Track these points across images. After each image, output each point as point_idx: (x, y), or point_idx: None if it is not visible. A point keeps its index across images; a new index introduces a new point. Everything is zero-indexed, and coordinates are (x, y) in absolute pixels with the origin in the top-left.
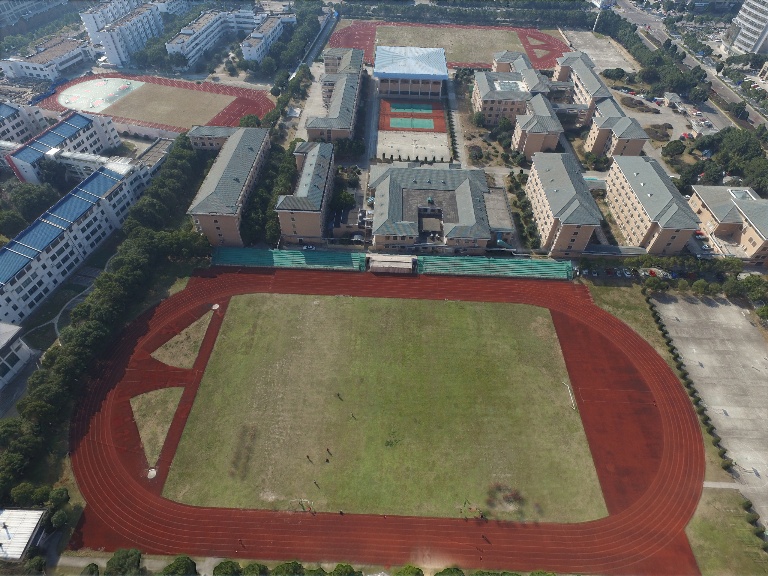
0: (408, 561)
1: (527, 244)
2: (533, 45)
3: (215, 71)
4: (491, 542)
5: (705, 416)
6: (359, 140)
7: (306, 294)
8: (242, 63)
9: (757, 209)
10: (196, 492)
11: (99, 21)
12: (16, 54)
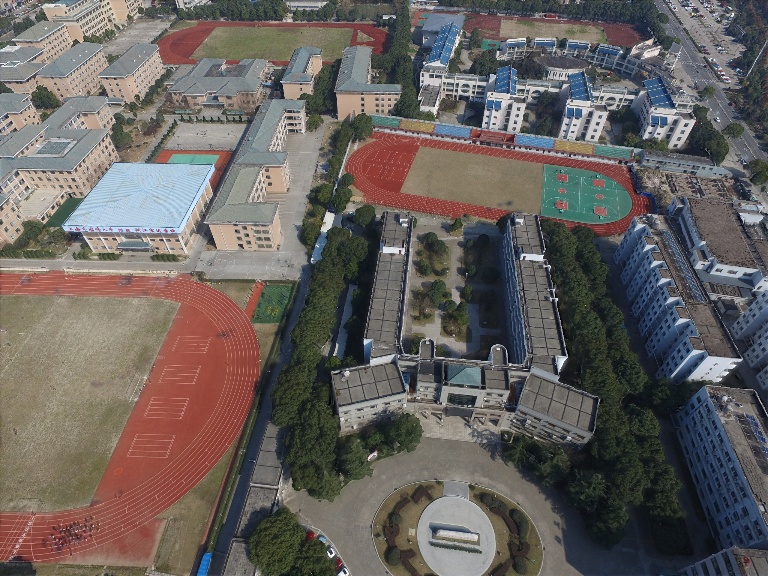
0: None
1: None
2: None
3: None
4: None
5: None
6: (259, 106)
7: None
8: None
9: (24, 54)
10: None
11: None
12: None
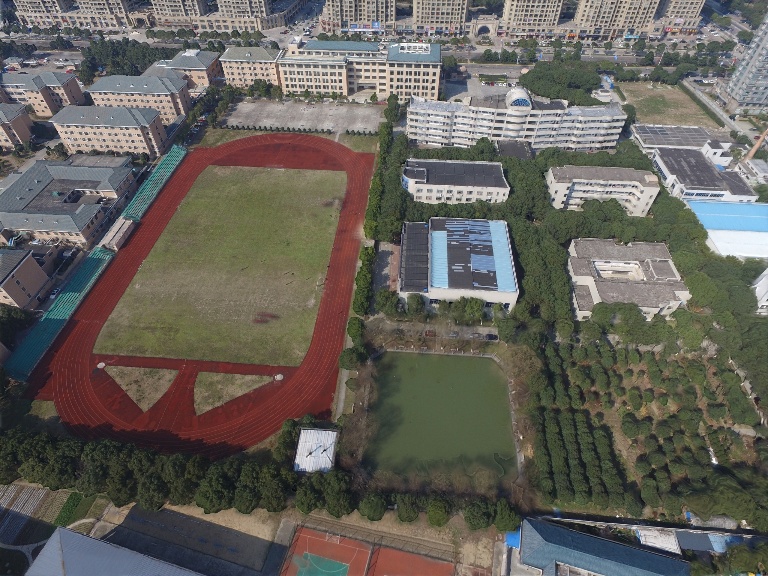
0: (358, 240)
1: (140, 164)
2: None
3: None
4: (353, 210)
5: (304, 129)
6: None
7: (123, 294)
8: None
9: (181, 61)
10: (300, 344)
11: None
12: None
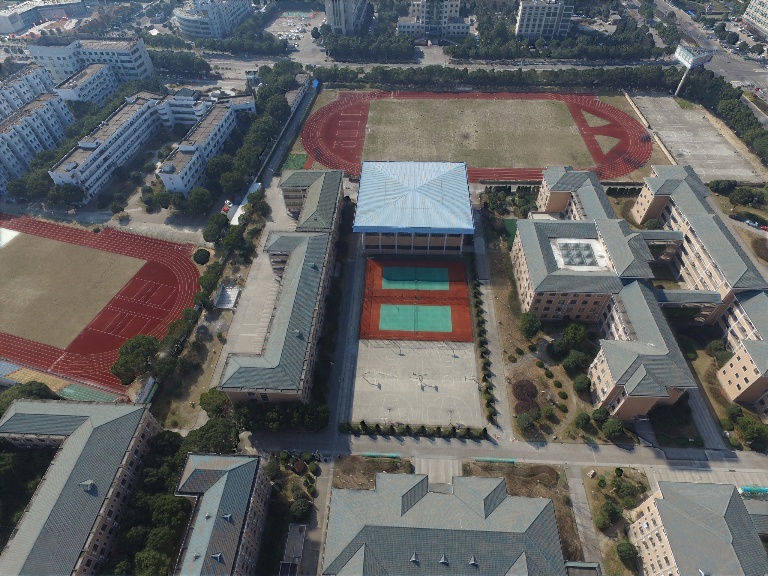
0: None
1: None
2: (593, 127)
3: None
4: None
5: None
6: (316, 407)
7: None
8: (160, 198)
9: None
10: None
11: None
12: None
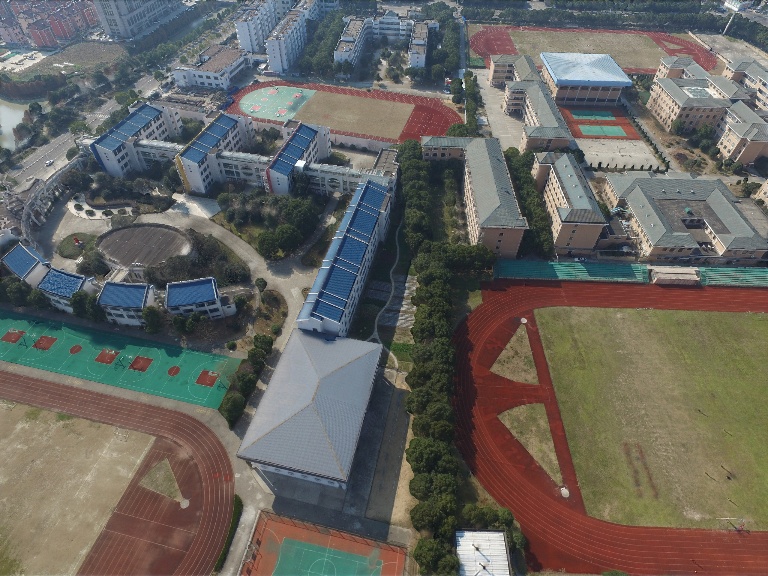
0: None
1: None
2: (673, 49)
3: (381, 78)
4: None
5: None
6: None
7: (605, 307)
8: (412, 70)
9: None
10: (620, 511)
11: (252, 28)
12: (172, 62)
